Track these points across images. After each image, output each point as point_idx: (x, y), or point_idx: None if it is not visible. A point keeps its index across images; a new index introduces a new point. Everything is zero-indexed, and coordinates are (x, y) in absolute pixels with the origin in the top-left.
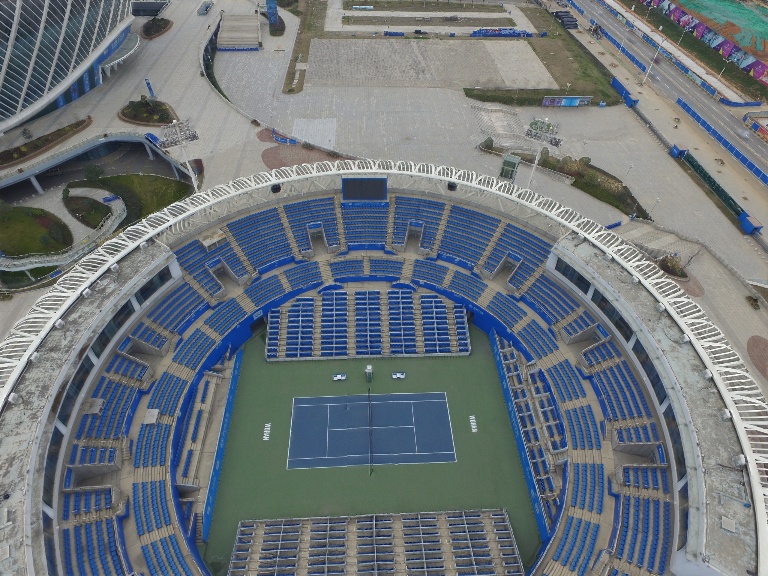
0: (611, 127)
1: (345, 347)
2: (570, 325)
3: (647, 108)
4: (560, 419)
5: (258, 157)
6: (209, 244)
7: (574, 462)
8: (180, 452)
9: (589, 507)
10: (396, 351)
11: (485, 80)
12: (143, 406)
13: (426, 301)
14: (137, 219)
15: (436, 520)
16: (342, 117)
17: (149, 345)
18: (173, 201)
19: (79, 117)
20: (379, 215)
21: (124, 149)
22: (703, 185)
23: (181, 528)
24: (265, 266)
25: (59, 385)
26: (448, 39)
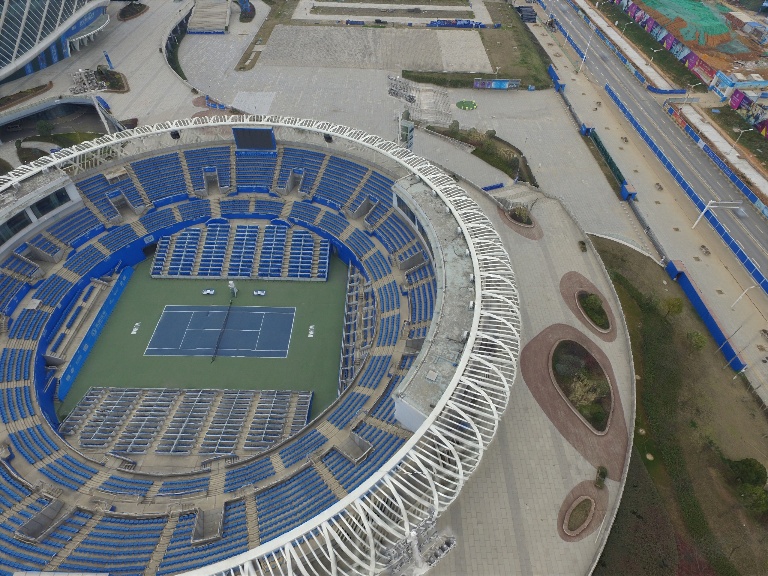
0: (533, 108)
1: (219, 269)
2: (404, 253)
3: (574, 93)
4: (374, 324)
5: None
6: (110, 177)
7: (373, 355)
8: (54, 334)
9: (369, 385)
10: (263, 274)
11: (425, 64)
12: (29, 297)
13: (297, 236)
14: None
15: (251, 395)
16: (281, 91)
17: (43, 251)
18: None
19: (43, 83)
20: (268, 163)
21: (81, 112)
22: (600, 159)
23: (35, 382)
24: (160, 200)
25: None
26: (403, 28)
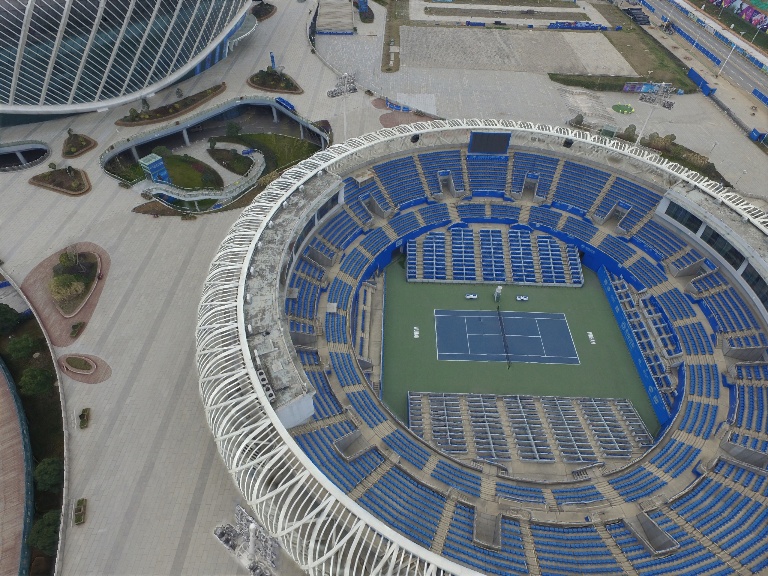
0: (690, 112)
1: (474, 274)
2: (678, 261)
3: (724, 97)
4: (673, 332)
5: (377, 121)
6: (362, 181)
7: (689, 364)
8: (355, 337)
9: (707, 394)
10: (518, 279)
11: (567, 66)
12: (324, 300)
13: (542, 241)
14: (275, 168)
15: (570, 402)
16: (439, 93)
17: (323, 255)
18: (306, 154)
19: (214, 83)
20: (499, 167)
21: (251, 113)
22: None
23: None
24: (404, 203)
25: (281, 267)
26: (528, 30)
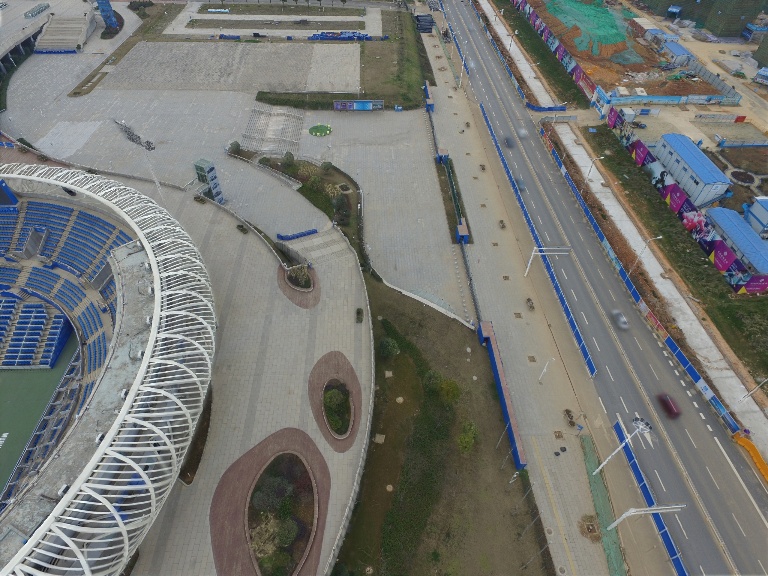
0: (393, 132)
1: None
2: None
3: (445, 112)
4: (55, 439)
5: None
6: None
7: None
8: None
9: None
10: None
11: (287, 83)
12: None
13: (28, 311)
14: None
15: None
16: (109, 120)
17: None
18: None
19: None
20: (8, 221)
21: None
22: (447, 191)
23: None
24: None
25: None
26: (279, 42)
